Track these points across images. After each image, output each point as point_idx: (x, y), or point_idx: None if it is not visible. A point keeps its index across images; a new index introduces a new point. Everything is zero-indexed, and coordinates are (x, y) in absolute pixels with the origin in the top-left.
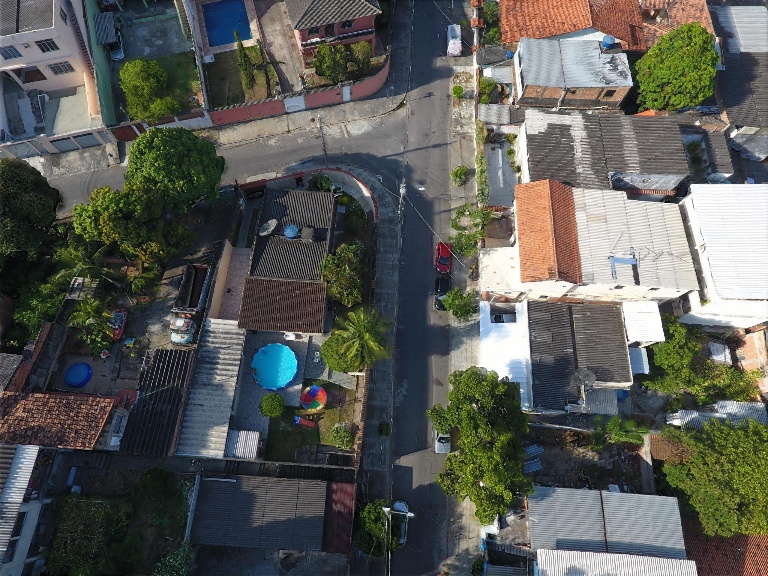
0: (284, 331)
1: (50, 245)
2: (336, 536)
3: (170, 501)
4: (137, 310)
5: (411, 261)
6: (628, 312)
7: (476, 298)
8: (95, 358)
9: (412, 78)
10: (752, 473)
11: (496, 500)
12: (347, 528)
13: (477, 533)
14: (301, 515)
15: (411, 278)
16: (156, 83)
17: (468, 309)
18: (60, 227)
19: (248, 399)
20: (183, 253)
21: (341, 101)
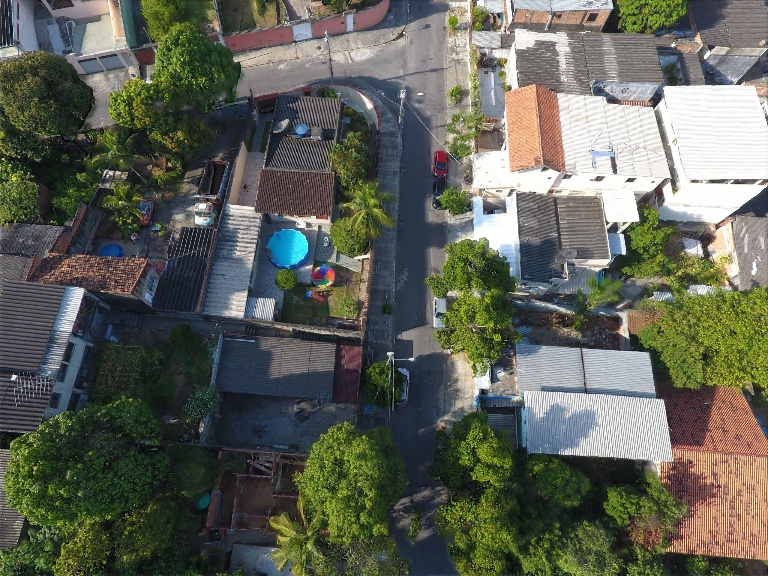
0: (296, 219)
1: (81, 150)
2: (345, 389)
3: (197, 355)
4: (162, 202)
5: (411, 168)
6: (607, 198)
7: (470, 199)
8: (126, 240)
9: (411, 12)
10: (715, 326)
11: (487, 342)
12: (355, 382)
13: (471, 394)
14: (313, 370)
15: (411, 183)
16: (175, 10)
17: (463, 203)
18: (90, 133)
19: (264, 277)
20: (202, 158)
21: (345, 31)
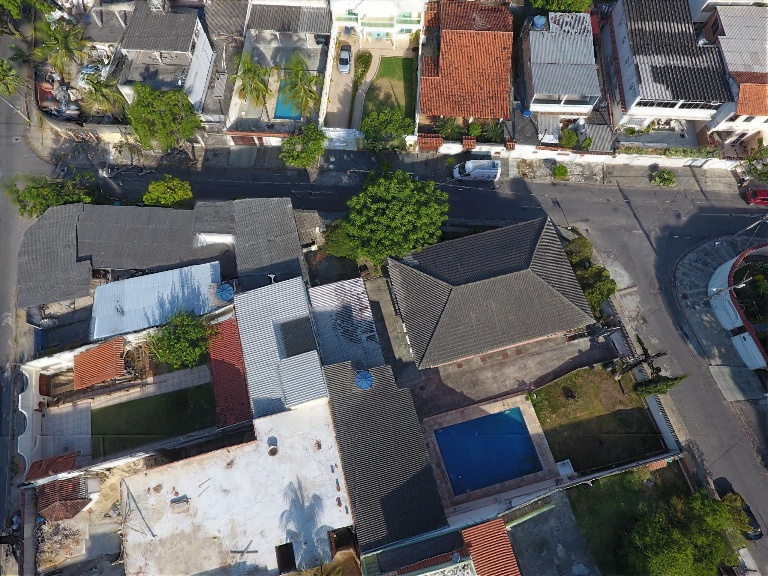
0: None
1: None
2: None
3: None
4: None
5: None
6: None
7: None
8: None
9: None
10: None
11: None
12: None
13: None
14: None
15: None
16: None
17: None
18: None
19: None
20: None
21: None
